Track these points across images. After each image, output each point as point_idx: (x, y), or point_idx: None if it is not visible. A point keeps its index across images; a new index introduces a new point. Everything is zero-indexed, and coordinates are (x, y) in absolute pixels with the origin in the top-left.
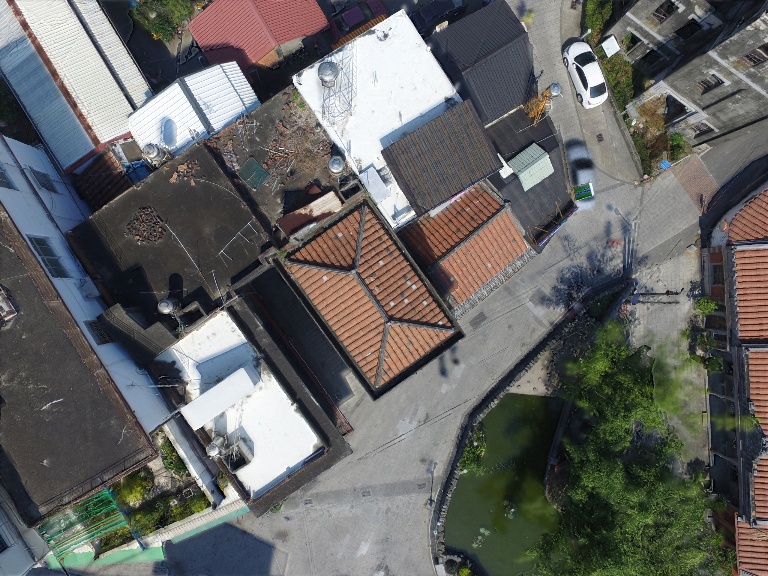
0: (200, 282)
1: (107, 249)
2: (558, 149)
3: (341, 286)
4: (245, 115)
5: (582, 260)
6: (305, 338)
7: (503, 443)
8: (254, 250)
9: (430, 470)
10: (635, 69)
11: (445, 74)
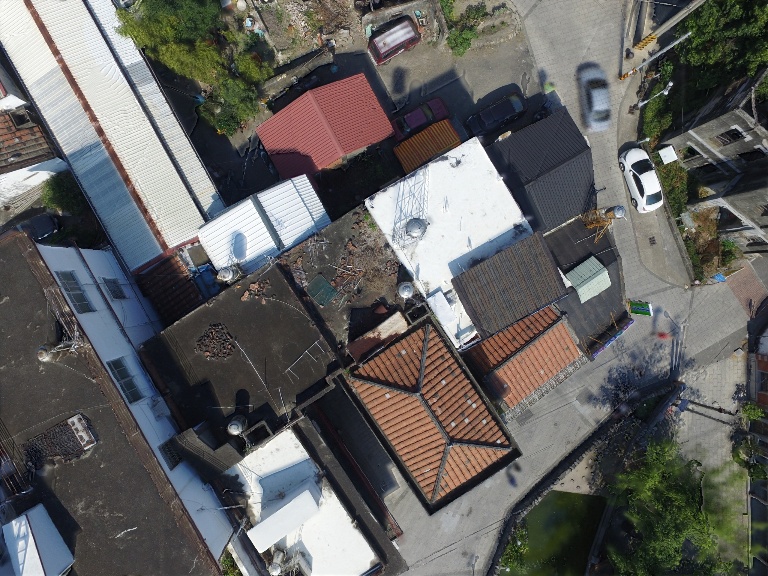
0: (266, 398)
1: (177, 363)
2: (616, 263)
3: (404, 405)
4: (315, 233)
5: (630, 361)
6: (353, 430)
7: (544, 539)
8: (320, 368)
9: (471, 563)
10: (690, 175)
11: (515, 201)
